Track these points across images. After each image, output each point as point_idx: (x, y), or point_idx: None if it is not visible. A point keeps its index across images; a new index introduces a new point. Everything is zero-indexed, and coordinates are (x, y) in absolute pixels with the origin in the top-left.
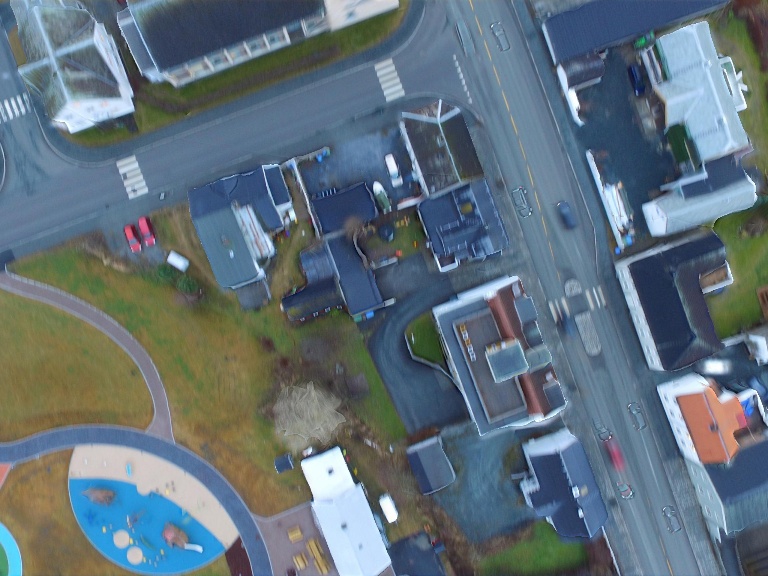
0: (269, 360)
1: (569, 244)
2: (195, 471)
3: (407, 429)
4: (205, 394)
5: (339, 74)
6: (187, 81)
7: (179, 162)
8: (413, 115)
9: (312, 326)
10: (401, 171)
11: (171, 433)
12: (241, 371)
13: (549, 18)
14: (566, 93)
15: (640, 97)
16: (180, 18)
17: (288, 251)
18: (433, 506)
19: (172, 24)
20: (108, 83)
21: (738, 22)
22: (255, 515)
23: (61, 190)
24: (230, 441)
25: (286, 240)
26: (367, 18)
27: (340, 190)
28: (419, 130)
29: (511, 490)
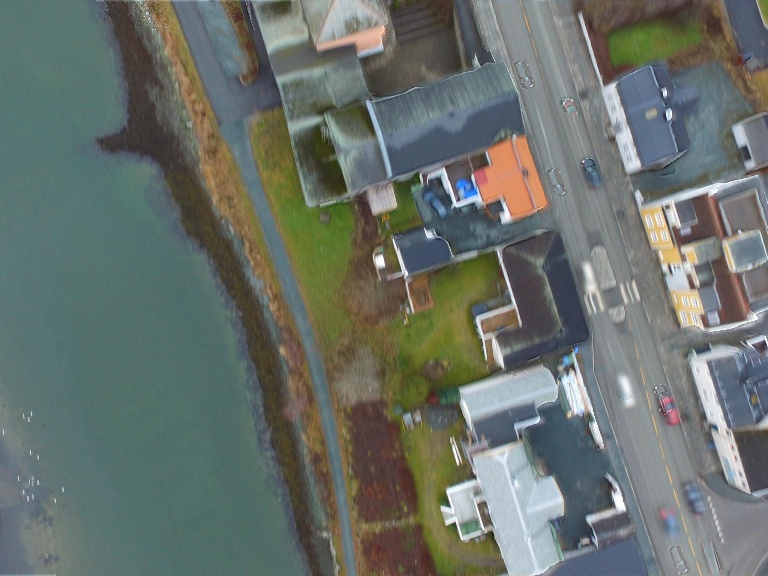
0: None
1: (620, 357)
2: None
3: None
4: None
5: None
6: None
7: None
8: None
9: None
10: None
11: None
12: None
13: None
14: None
15: None
16: None
17: None
18: None
19: None
20: None
21: (445, 573)
22: None
23: None
24: None
25: None
26: None
27: None
28: None
29: None
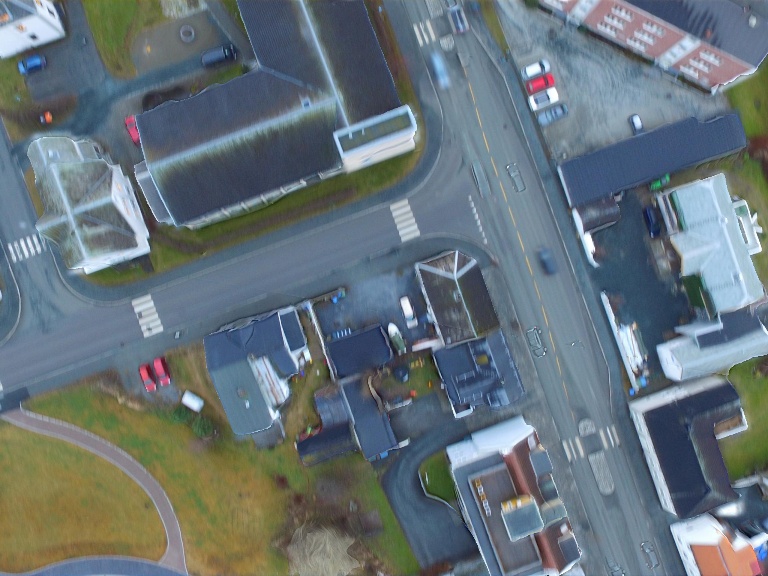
0: (283, 497)
1: (583, 384)
2: None
3: (420, 564)
4: (218, 527)
5: (355, 214)
6: (203, 225)
7: (194, 301)
8: (429, 268)
9: (326, 464)
10: (416, 313)
11: (184, 565)
12: (255, 507)
13: (565, 162)
14: (581, 236)
15: (655, 238)
16: (198, 175)
17: (303, 390)
18: None
19: (190, 181)
20: (125, 234)
21: (753, 163)
22: None
23: (76, 328)
24: (243, 573)
25: (301, 380)
26: (383, 160)
27: (355, 331)
28: (435, 283)
29: None
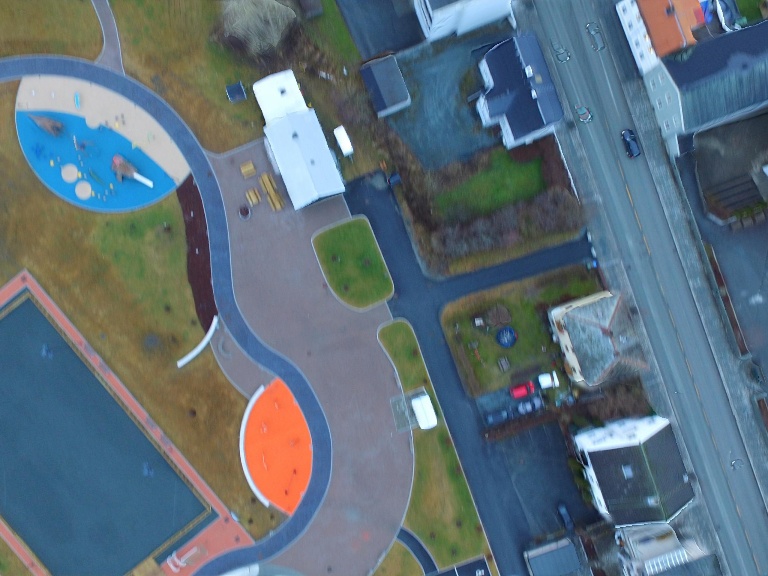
0: None
1: None
2: (145, 104)
3: (362, 56)
4: (155, 21)
5: None
6: None
7: None
8: None
9: None
10: None
11: (121, 64)
12: None
13: None
14: None
15: None
16: None
17: None
18: (388, 132)
19: None
20: None
21: None
22: (207, 151)
23: None
24: (181, 73)
25: None
26: None
27: None
28: None
29: (468, 116)
